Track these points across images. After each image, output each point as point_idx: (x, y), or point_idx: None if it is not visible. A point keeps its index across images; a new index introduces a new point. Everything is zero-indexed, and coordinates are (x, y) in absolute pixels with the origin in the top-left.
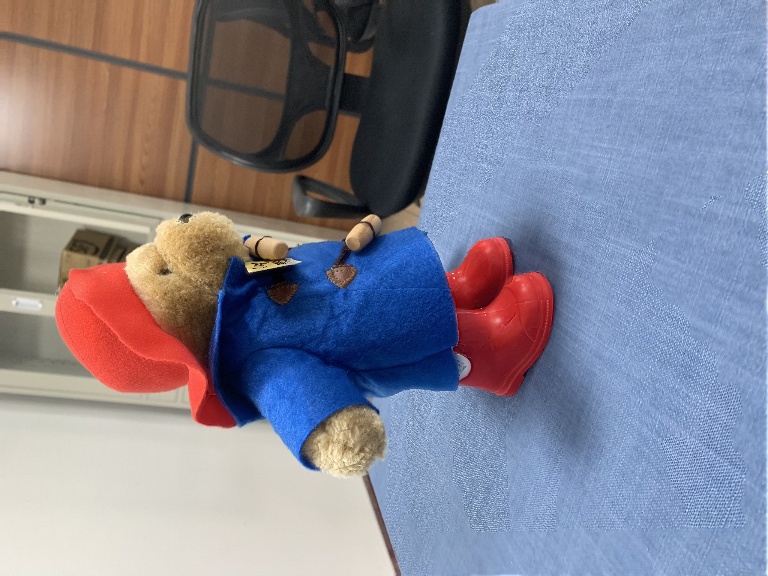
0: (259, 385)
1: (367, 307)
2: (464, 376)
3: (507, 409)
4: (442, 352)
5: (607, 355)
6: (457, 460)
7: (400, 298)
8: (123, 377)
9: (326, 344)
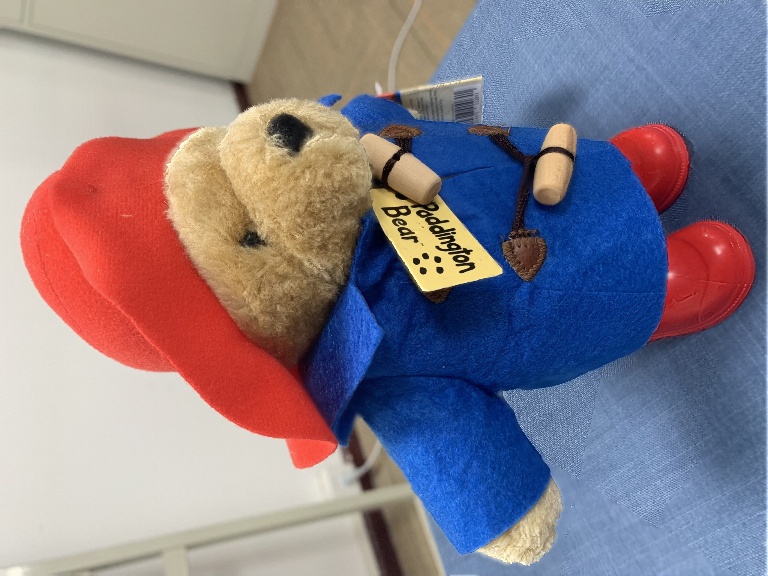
0: (401, 435)
1: (560, 320)
2: None
3: None
4: None
5: None
6: None
7: (605, 308)
8: (163, 369)
9: (496, 374)
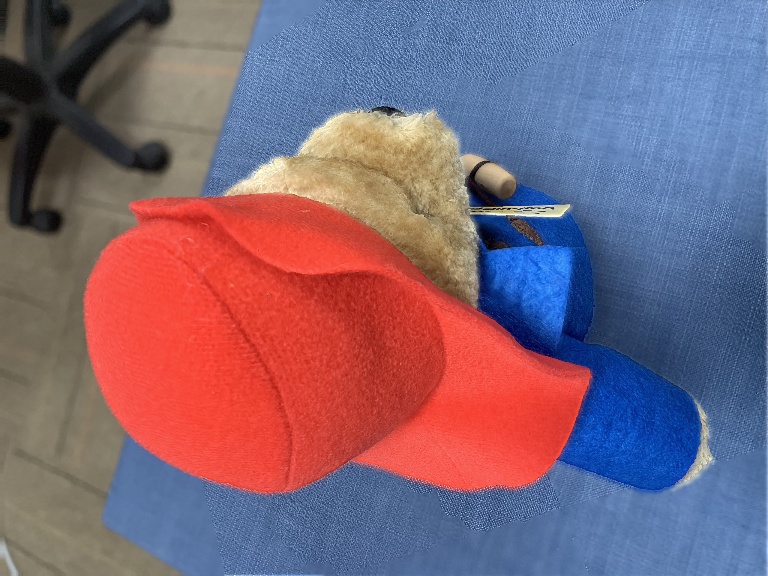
0: None
1: None
2: None
3: None
4: None
5: (687, 305)
6: None
7: (581, 259)
8: (355, 445)
9: (578, 322)
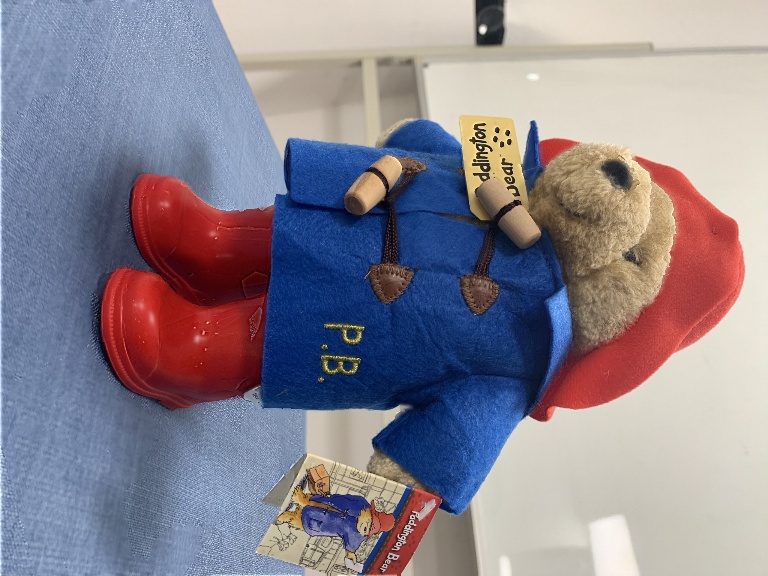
0: None
1: None
2: None
3: None
4: None
5: None
6: None
7: None
8: None
9: None
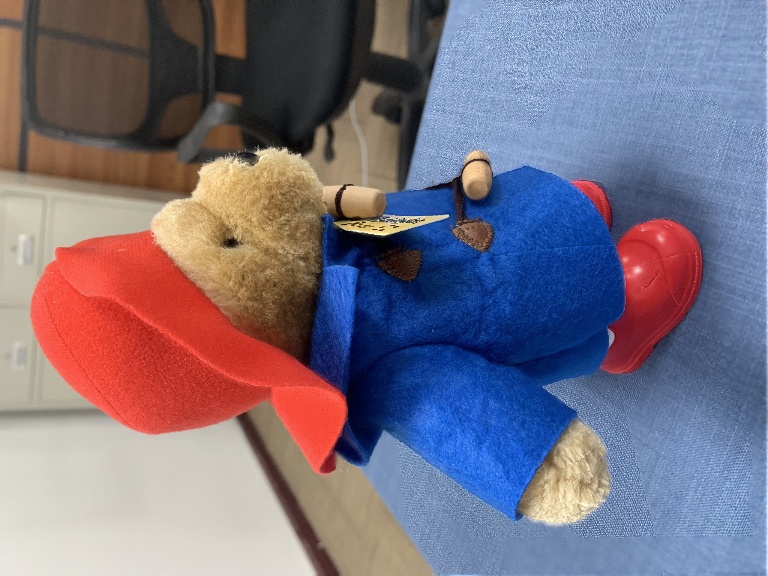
0: (412, 404)
1: (527, 276)
2: None
3: (624, 389)
4: None
5: None
6: None
7: (564, 261)
8: (169, 412)
9: (486, 333)
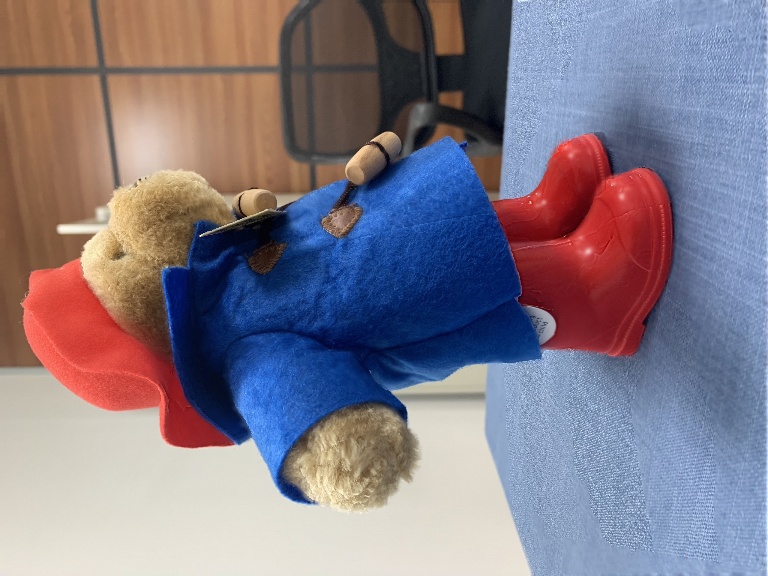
0: (236, 388)
1: (374, 259)
2: (549, 336)
3: (628, 374)
4: (502, 307)
5: (767, 274)
6: (577, 445)
7: (420, 238)
8: (103, 393)
9: (322, 319)
